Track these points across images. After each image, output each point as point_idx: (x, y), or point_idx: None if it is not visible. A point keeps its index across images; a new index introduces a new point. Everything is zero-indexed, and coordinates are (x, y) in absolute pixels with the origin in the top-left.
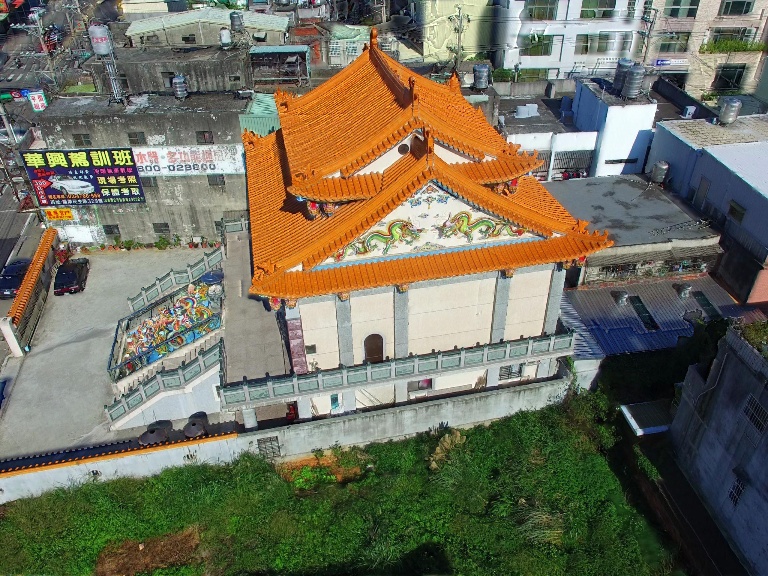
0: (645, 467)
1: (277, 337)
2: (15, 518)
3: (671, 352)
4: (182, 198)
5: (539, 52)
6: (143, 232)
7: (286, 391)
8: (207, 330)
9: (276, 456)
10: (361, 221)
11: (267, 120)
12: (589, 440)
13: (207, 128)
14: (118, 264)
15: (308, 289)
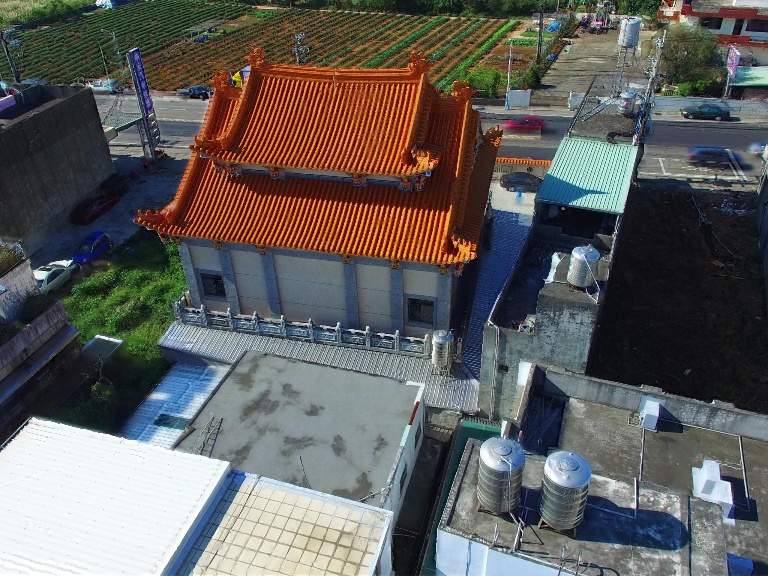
0: None
1: None
2: None
3: None
4: None
5: None
6: None
7: None
8: None
9: None
10: None
11: None
12: None
13: None
14: None
15: None
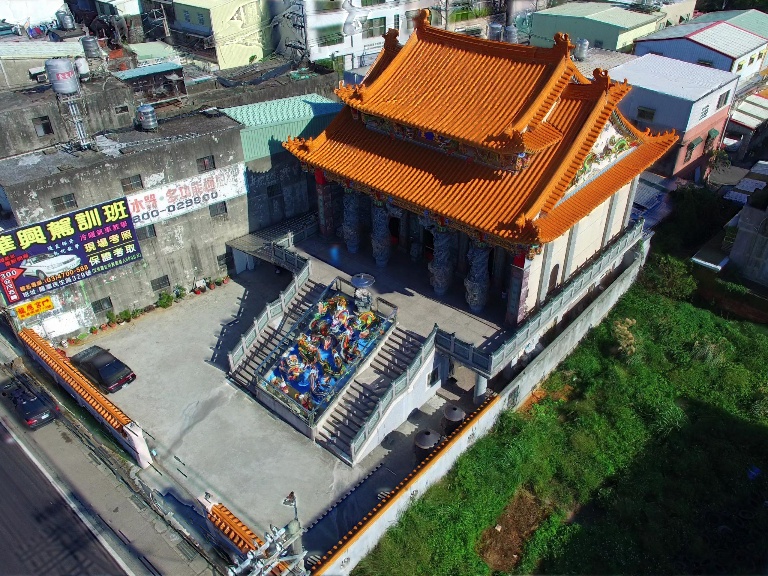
0: (736, 288)
1: (450, 310)
2: (384, 575)
3: (675, 218)
4: (183, 241)
5: (335, 41)
6: (140, 295)
7: (523, 339)
8: (381, 332)
9: (513, 407)
10: (572, 160)
11: (267, 130)
12: (667, 297)
13: (208, 153)
14: (136, 338)
15: (558, 229)
